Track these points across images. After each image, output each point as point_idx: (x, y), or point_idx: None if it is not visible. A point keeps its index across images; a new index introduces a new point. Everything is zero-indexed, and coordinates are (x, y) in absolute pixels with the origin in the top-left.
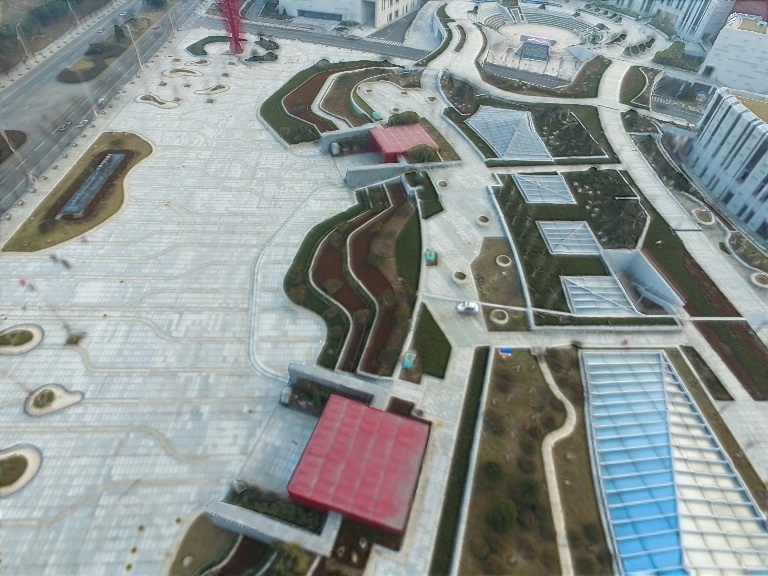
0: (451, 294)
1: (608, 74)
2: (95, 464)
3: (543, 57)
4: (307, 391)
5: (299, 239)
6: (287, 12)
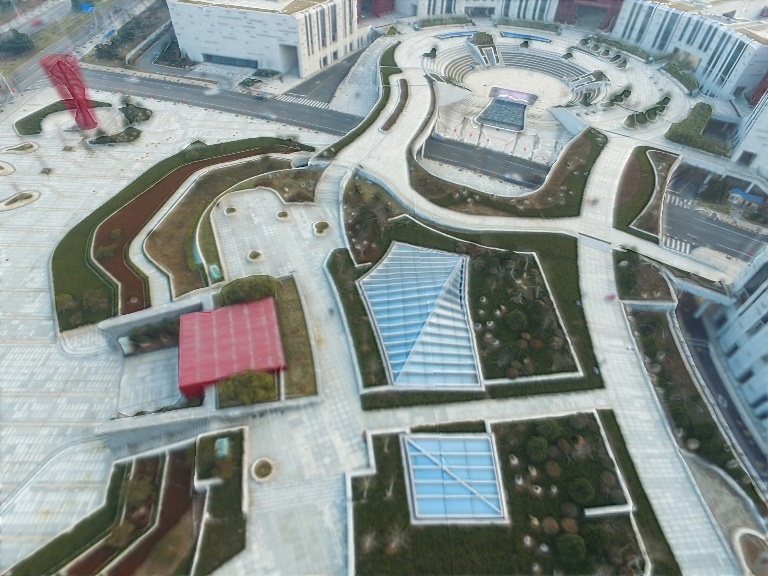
0: None
1: (599, 167)
2: None
3: (516, 123)
4: None
5: None
6: (190, 56)
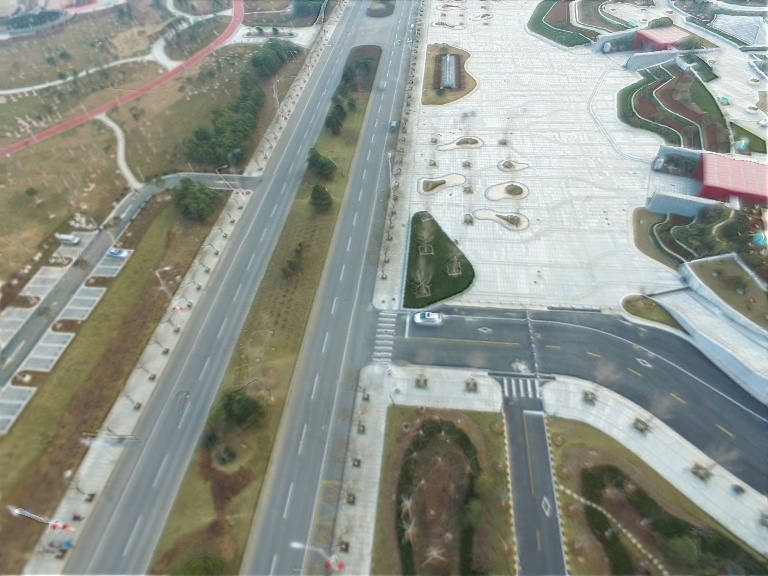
0: (749, 118)
1: None
2: (559, 190)
3: None
4: (674, 161)
5: (612, 98)
6: None
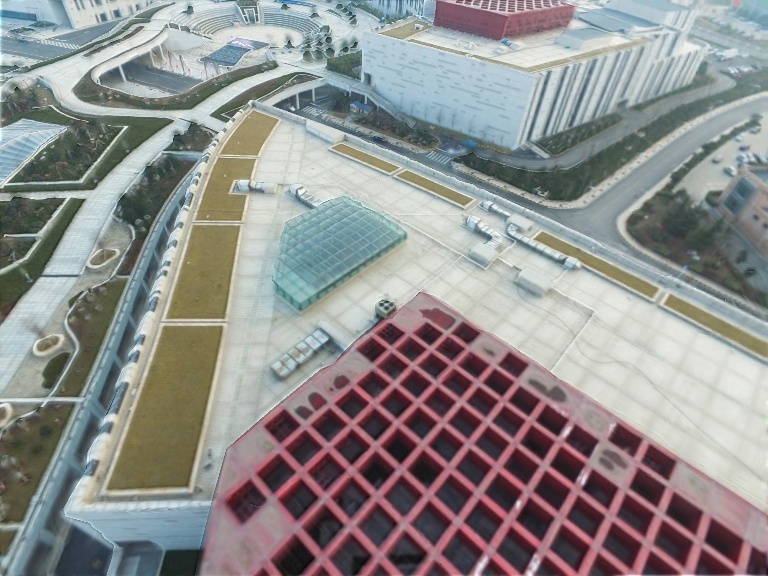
0: None
1: (242, 82)
2: None
3: (232, 62)
4: None
5: None
6: None
